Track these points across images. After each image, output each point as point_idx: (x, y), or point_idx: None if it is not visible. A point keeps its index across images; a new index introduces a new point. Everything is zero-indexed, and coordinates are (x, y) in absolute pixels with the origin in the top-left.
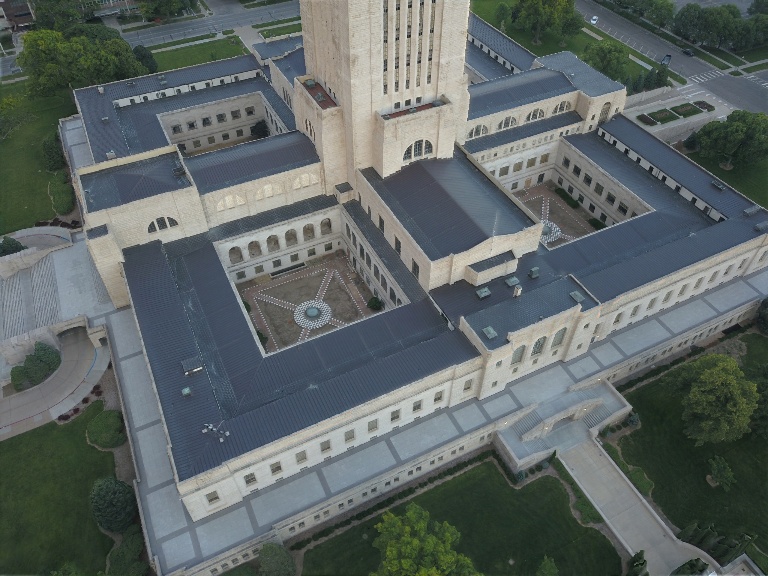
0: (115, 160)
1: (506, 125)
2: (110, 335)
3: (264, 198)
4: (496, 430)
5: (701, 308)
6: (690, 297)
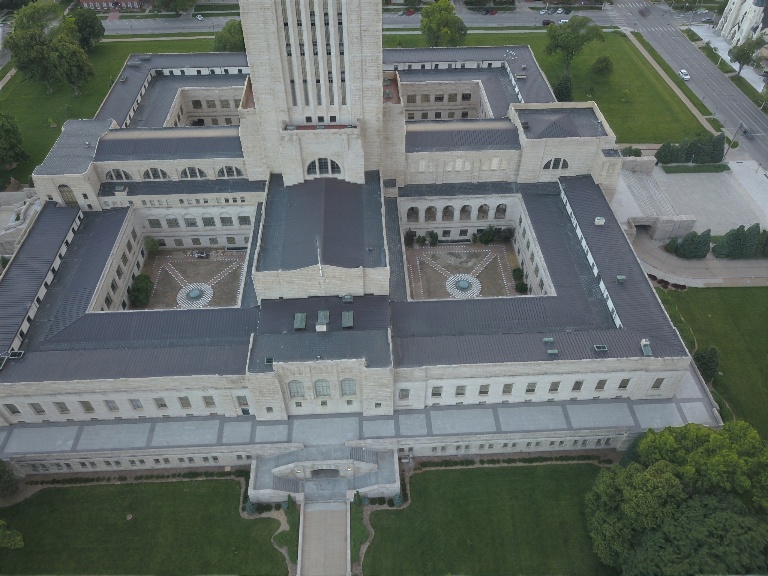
0: (581, 138)
1: None
2: None
3: None
4: None
5: None
6: None
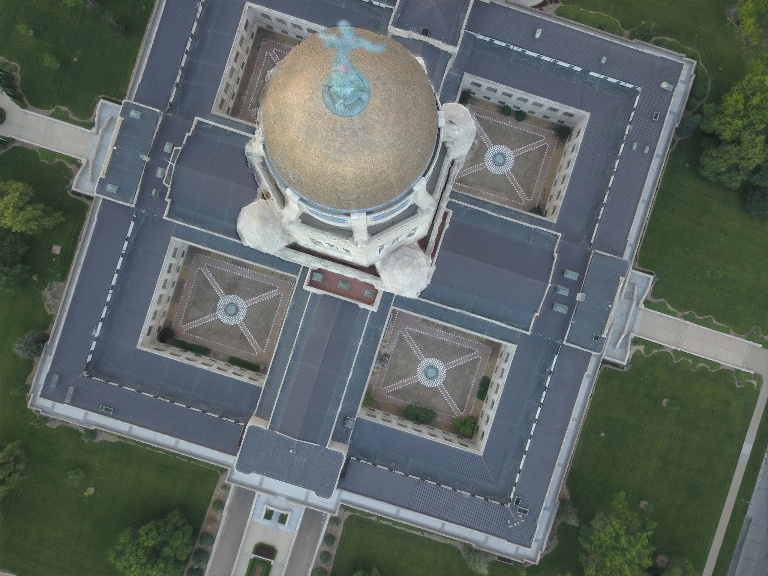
0: None
1: None
2: None
3: None
4: None
5: None
6: None
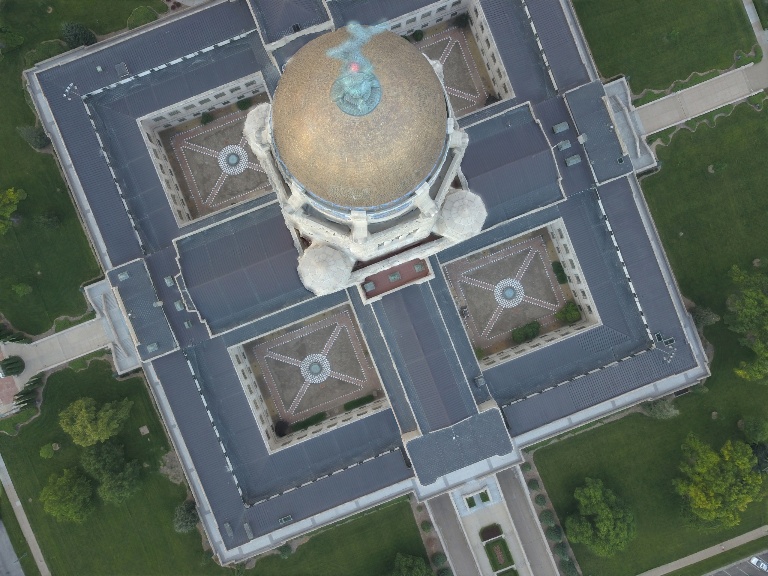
0: None
1: None
2: (206, 4)
3: None
4: None
5: None
6: None
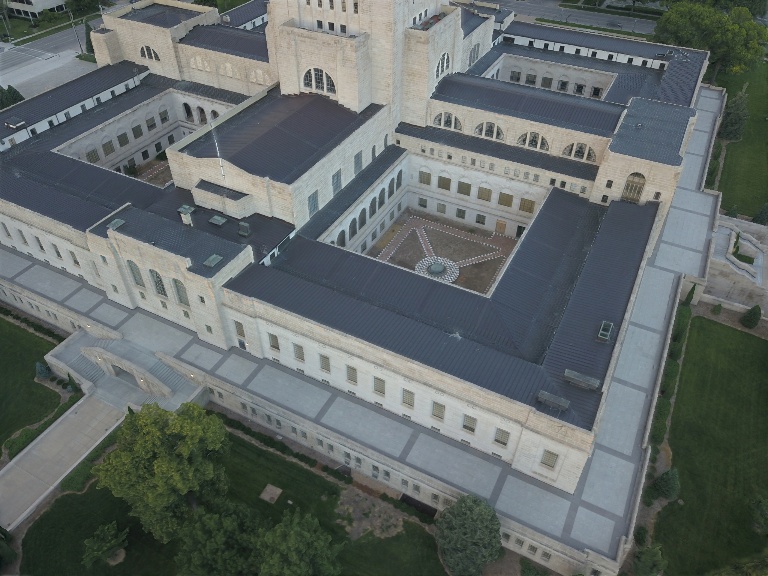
0: (176, 1)
1: (490, 134)
2: None
3: (225, 75)
4: (82, 327)
5: (394, 435)
6: (405, 416)
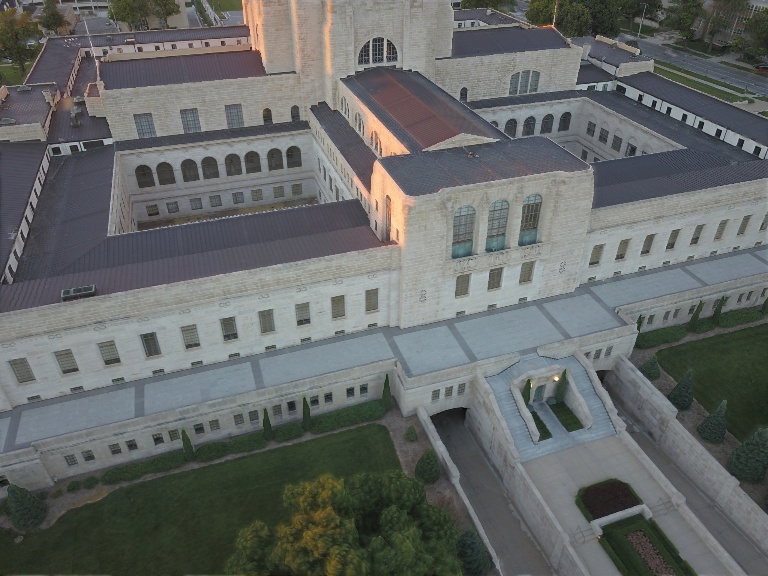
0: None
1: None
2: None
3: None
4: None
5: None
6: None
